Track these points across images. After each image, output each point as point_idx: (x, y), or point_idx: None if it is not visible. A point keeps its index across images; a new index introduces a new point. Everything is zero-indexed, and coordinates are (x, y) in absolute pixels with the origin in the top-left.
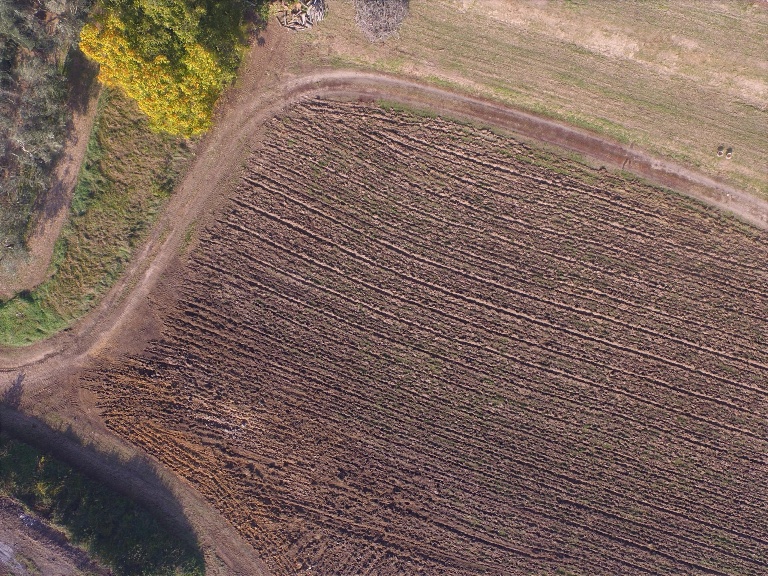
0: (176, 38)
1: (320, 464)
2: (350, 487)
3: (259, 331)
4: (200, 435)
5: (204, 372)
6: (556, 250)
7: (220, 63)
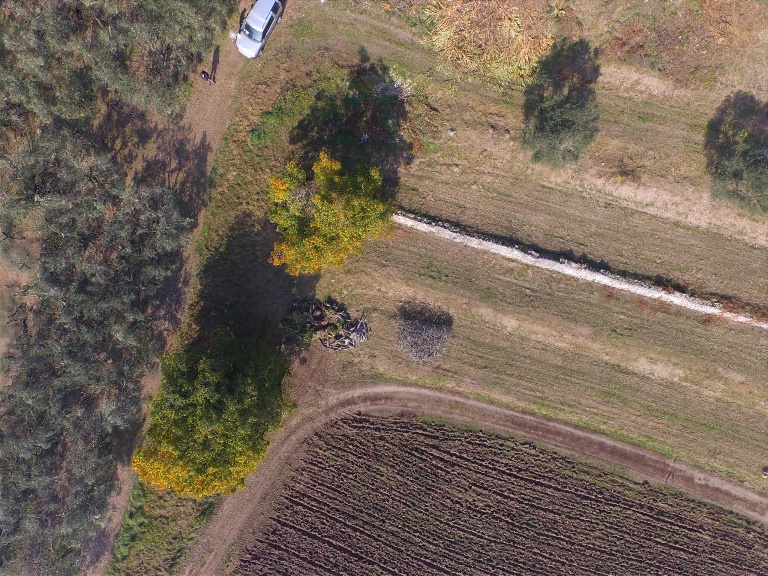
0: None
1: None
2: None
3: None
4: None
5: None
6: (598, 567)
7: None
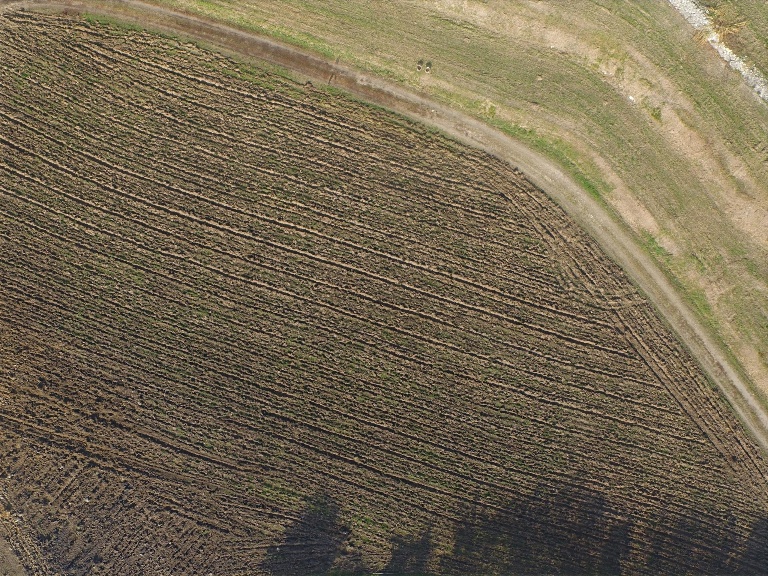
0: None
1: (20, 373)
2: (50, 397)
3: None
4: None
5: None
6: (260, 163)
7: None
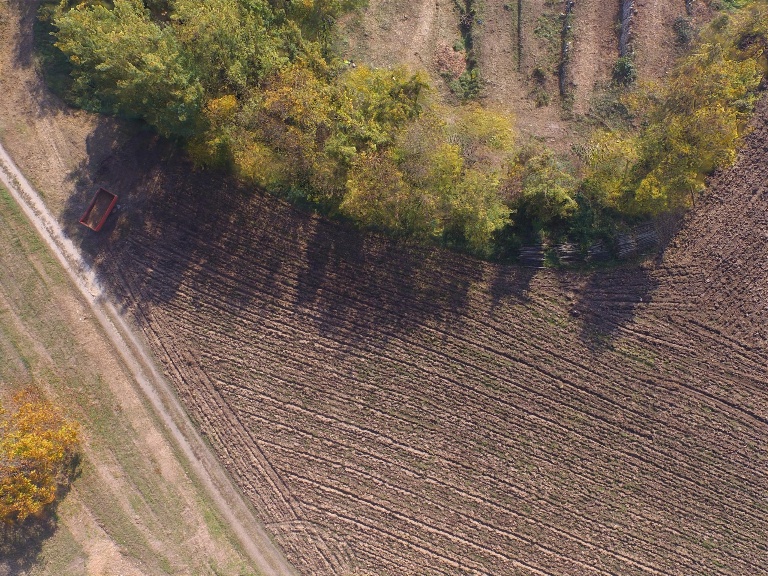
0: None
1: None
2: None
3: None
4: None
5: None
6: None
7: None
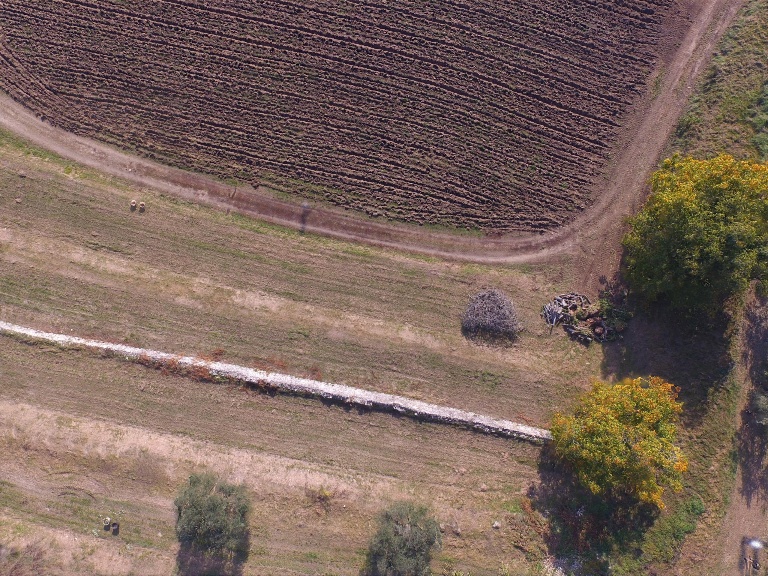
0: None
1: None
2: None
3: (581, 1)
4: None
5: None
6: (297, 103)
7: None
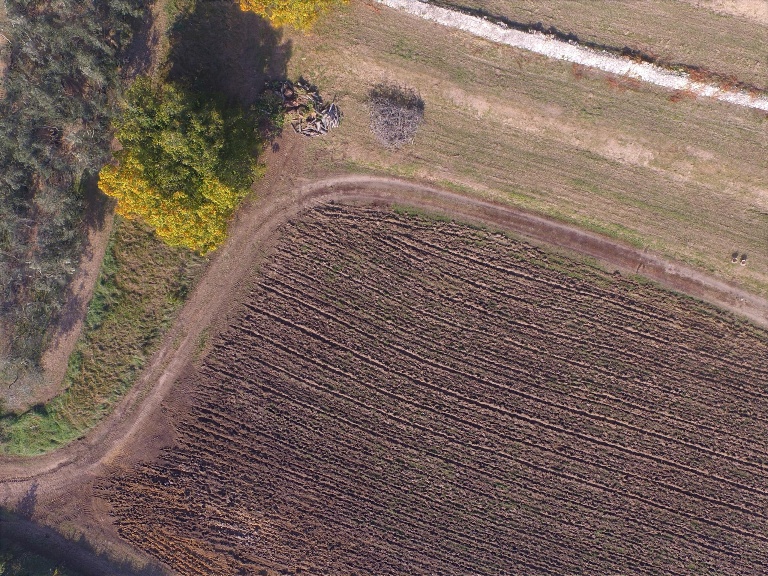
0: (194, 172)
1: (333, 570)
2: None
3: (272, 437)
4: (213, 542)
5: (217, 479)
6: (570, 355)
7: (236, 180)
